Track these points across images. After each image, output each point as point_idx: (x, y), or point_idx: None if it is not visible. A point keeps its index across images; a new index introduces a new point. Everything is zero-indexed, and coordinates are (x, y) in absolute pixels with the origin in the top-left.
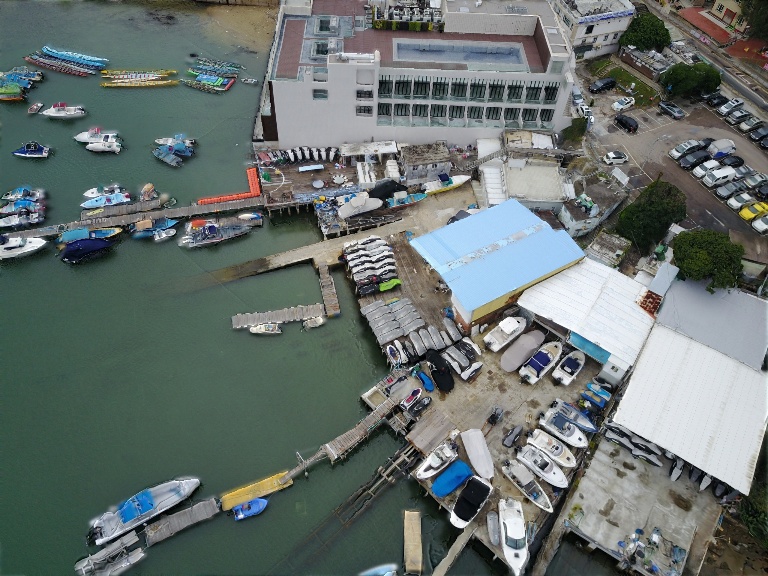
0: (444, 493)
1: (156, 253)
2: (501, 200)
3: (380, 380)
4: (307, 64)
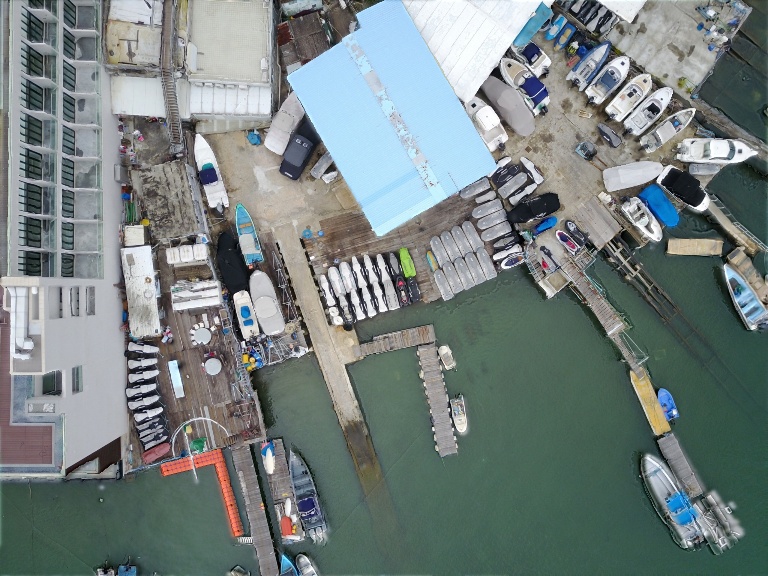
0: (676, 215)
1: (334, 572)
2: (263, 95)
3: (518, 276)
4: (2, 411)
